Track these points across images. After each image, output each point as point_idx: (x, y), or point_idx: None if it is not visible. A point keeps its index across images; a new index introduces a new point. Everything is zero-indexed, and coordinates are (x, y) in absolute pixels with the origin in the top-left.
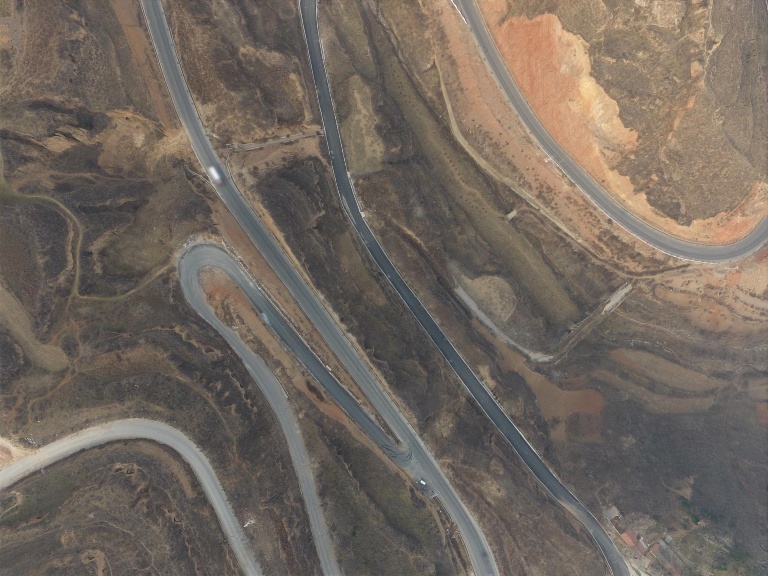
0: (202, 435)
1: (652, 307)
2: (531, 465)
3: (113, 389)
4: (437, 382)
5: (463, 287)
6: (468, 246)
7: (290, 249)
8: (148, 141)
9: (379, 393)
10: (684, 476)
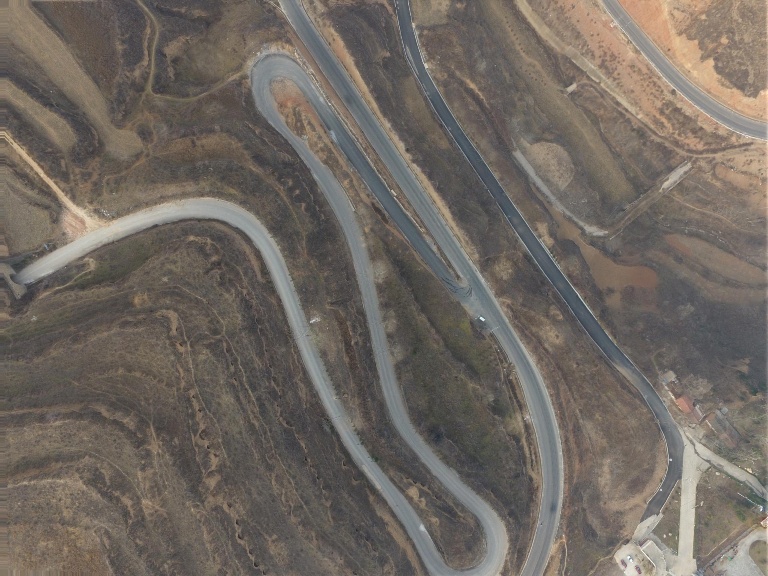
0: (274, 223)
1: (710, 190)
2: (586, 326)
3: (188, 170)
4: (498, 227)
5: (522, 151)
6: (527, 113)
7: (359, 74)
8: None
9: (441, 227)
10: (740, 354)
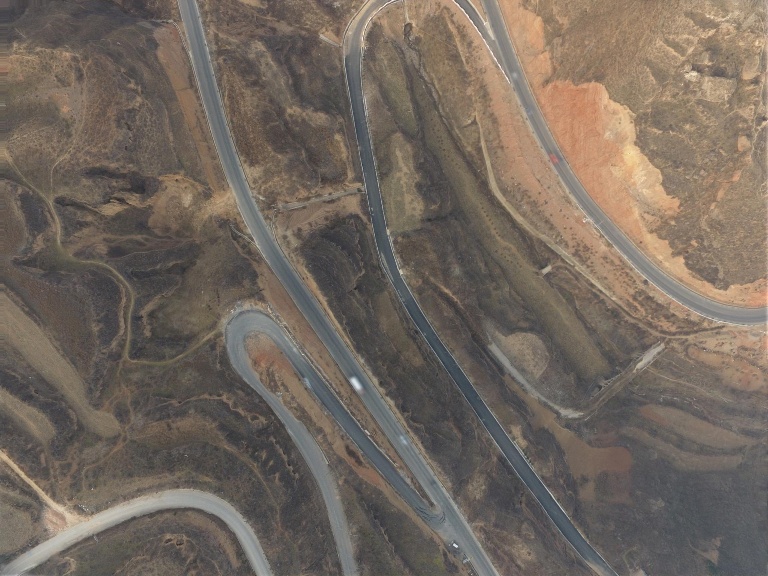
0: (248, 505)
1: (684, 366)
2: (560, 525)
3: (163, 458)
4: (471, 444)
5: (497, 344)
6: (502, 302)
7: (332, 313)
8: (196, 201)
9: (415, 456)
10: (711, 538)
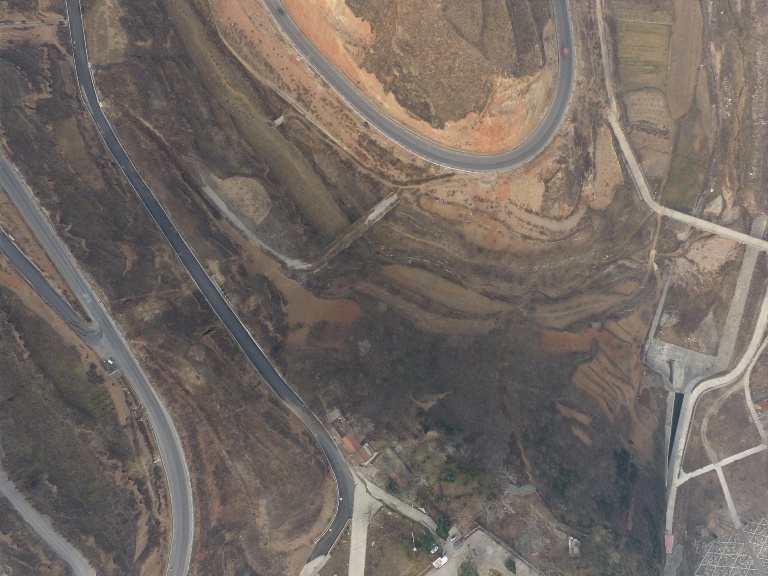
0: None
1: (423, 220)
2: (256, 364)
3: None
4: (146, 267)
5: (211, 186)
6: (225, 147)
7: None
8: None
9: (72, 270)
10: (432, 390)
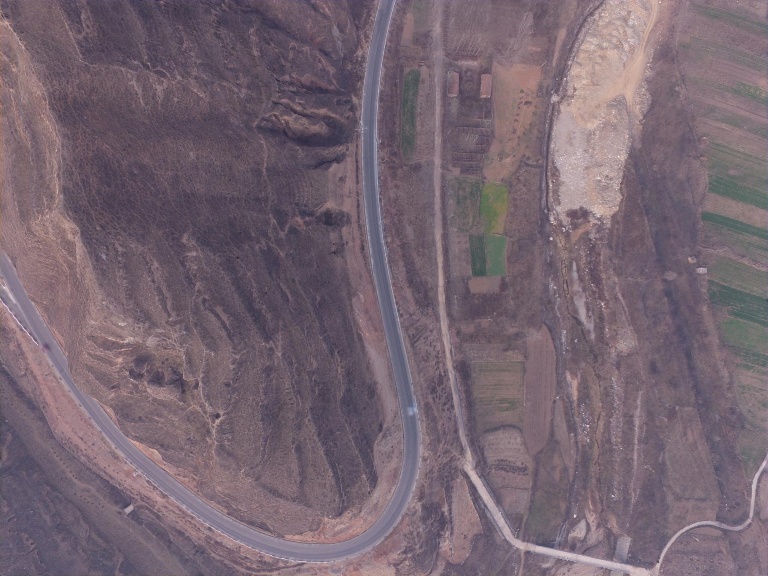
0: None
1: None
2: None
3: None
4: None
5: None
6: (72, 553)
7: None
8: None
9: None
10: None
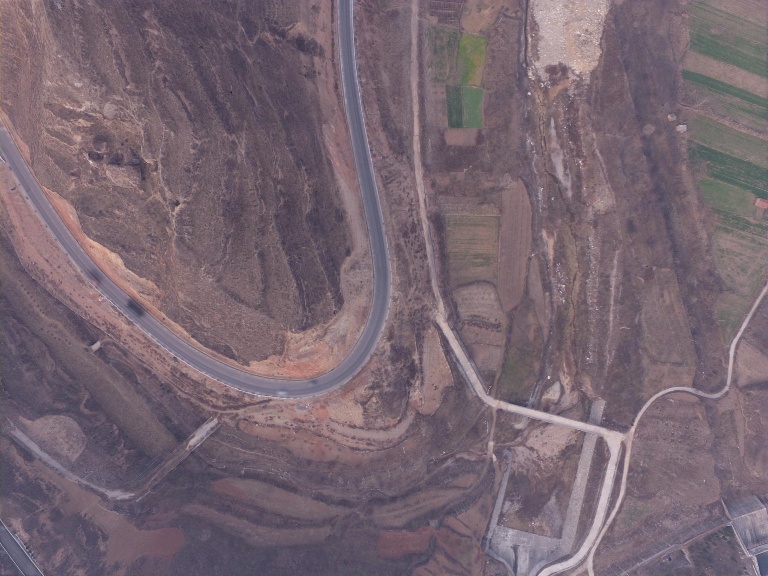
0: None
1: (248, 439)
2: None
3: None
4: None
5: (21, 429)
6: (36, 383)
7: None
8: None
9: None
10: None
